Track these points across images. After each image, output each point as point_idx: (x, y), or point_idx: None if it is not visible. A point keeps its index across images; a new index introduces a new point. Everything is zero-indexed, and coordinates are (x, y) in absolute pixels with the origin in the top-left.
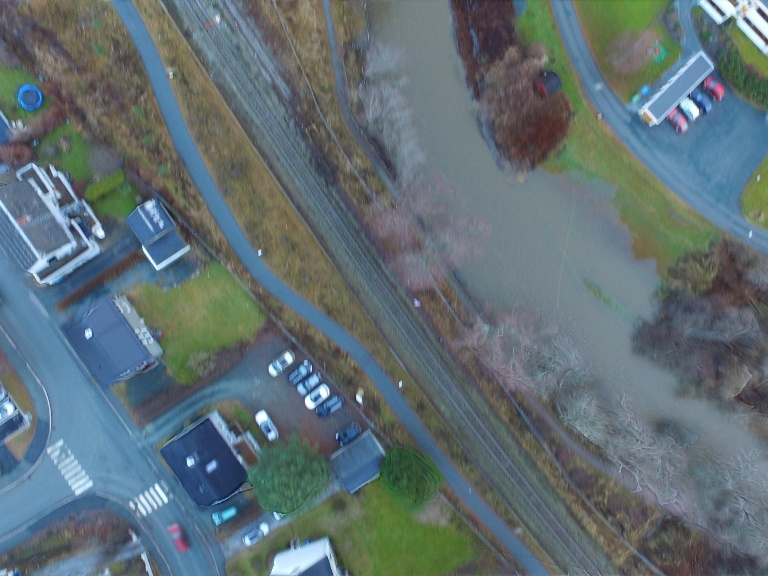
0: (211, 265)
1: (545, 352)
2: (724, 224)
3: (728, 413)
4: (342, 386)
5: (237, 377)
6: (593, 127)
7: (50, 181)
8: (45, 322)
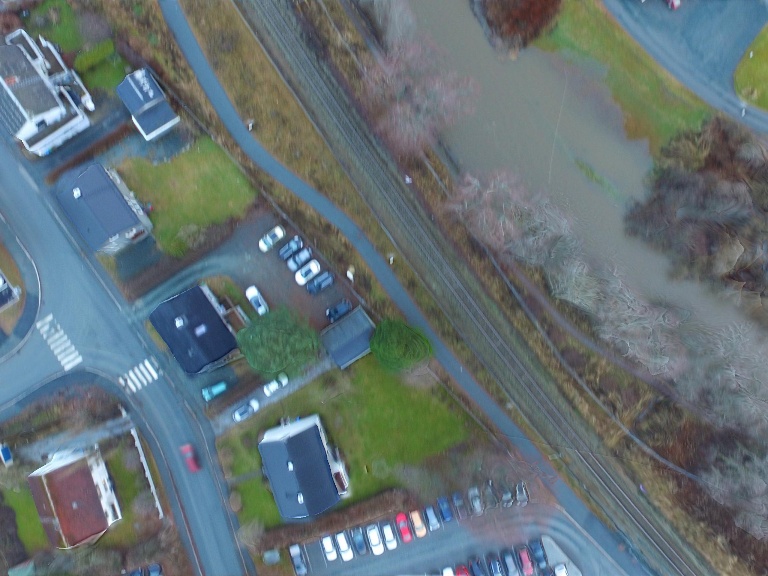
0: (201, 140)
1: (536, 217)
2: (717, 102)
3: (721, 291)
4: (333, 262)
5: (227, 253)
6: (585, 3)
7: (39, 51)
8: (34, 196)
